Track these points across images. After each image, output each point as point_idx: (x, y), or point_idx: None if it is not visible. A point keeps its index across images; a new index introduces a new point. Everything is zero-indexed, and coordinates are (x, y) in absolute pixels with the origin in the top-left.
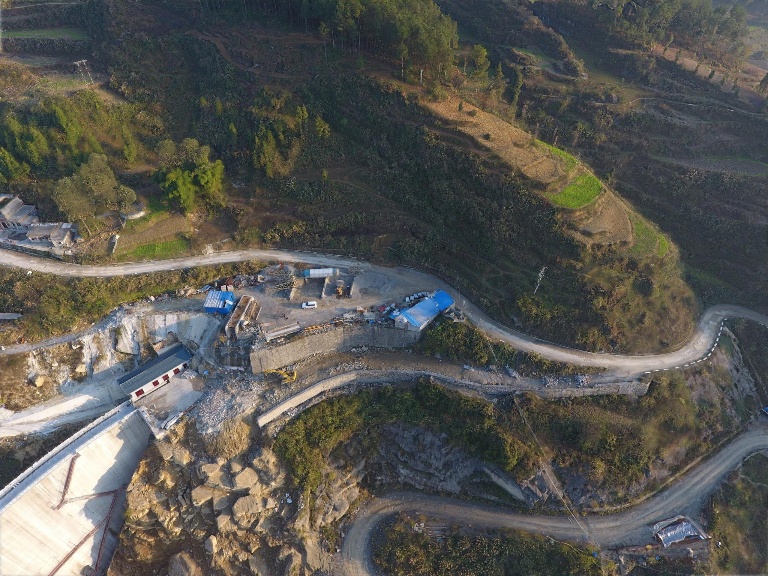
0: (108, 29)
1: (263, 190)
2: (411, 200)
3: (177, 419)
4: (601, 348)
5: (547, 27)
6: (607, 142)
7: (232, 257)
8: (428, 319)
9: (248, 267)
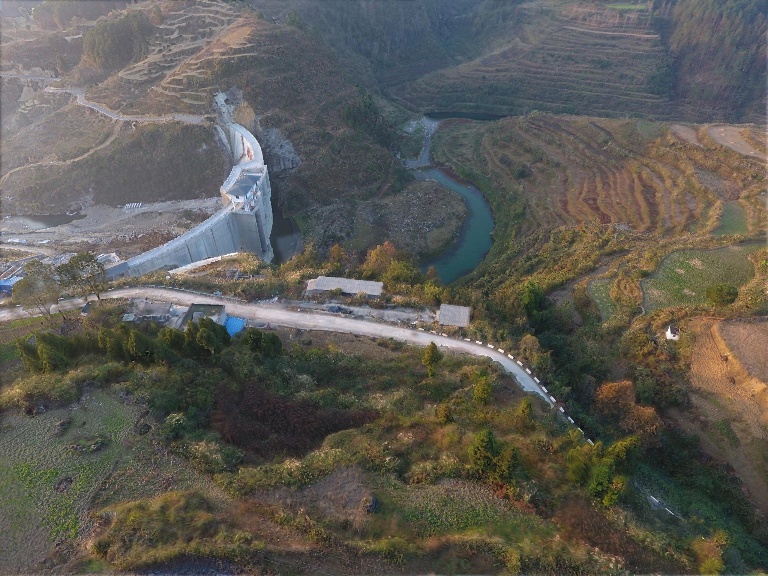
0: None
1: None
2: None
3: None
4: None
5: None
6: None
7: None
8: None
9: None
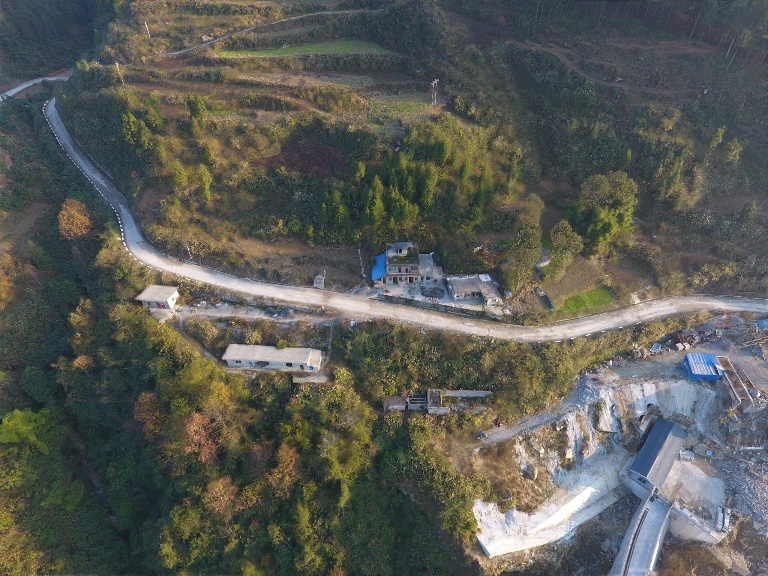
0: (439, 42)
1: (669, 226)
2: None
3: (729, 518)
4: None
5: None
6: None
7: (666, 307)
8: None
9: (696, 320)
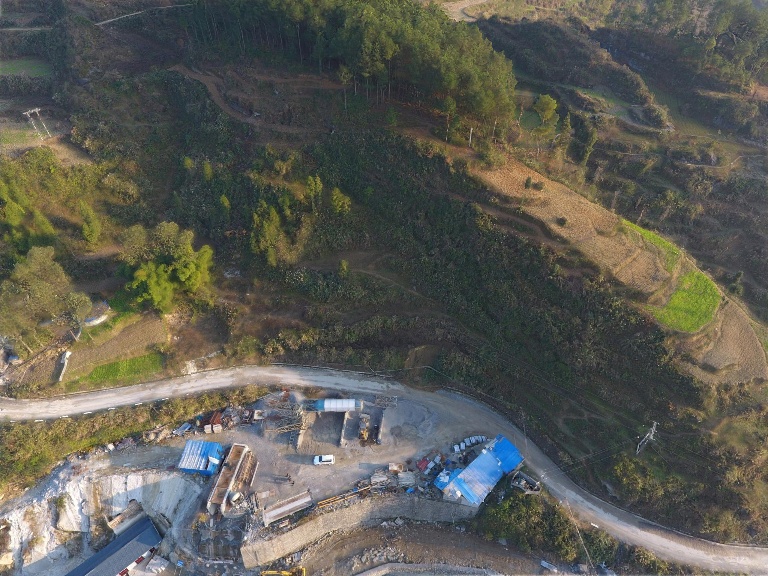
0: (71, 67)
1: (263, 283)
2: (458, 301)
3: None
4: (735, 538)
5: (614, 60)
6: (704, 215)
7: (221, 380)
8: (489, 489)
9: (241, 397)
